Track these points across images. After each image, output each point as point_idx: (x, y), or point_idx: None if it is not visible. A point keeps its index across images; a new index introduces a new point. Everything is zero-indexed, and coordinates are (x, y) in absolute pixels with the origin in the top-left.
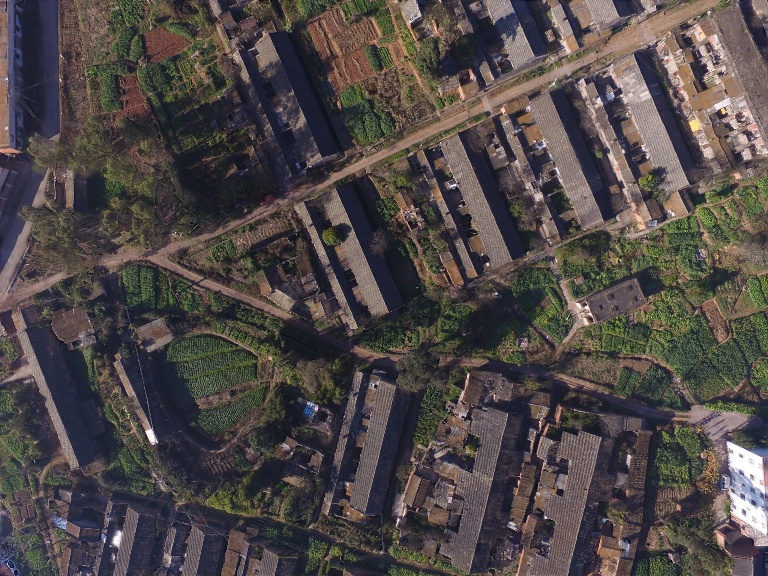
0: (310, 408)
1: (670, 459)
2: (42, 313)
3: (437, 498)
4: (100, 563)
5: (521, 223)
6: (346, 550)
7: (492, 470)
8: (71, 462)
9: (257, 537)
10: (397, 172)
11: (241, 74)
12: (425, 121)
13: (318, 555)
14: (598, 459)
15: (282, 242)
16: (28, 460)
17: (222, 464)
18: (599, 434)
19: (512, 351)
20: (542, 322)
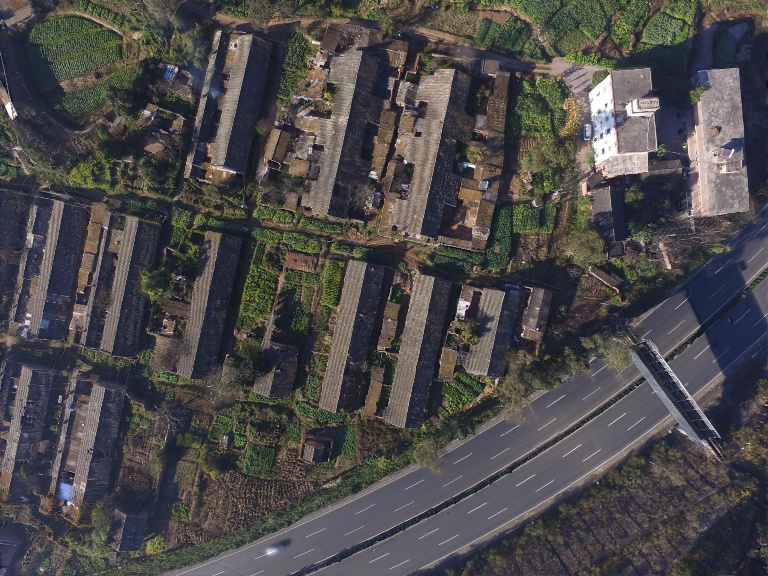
0: (170, 71)
1: (531, 107)
2: None
3: (298, 151)
4: None
5: None
6: (211, 218)
7: (348, 109)
8: None
9: (120, 208)
10: None
11: None
12: None
13: (182, 223)
14: (453, 92)
15: None
16: None
17: (87, 144)
18: (453, 67)
19: (373, 8)
20: None
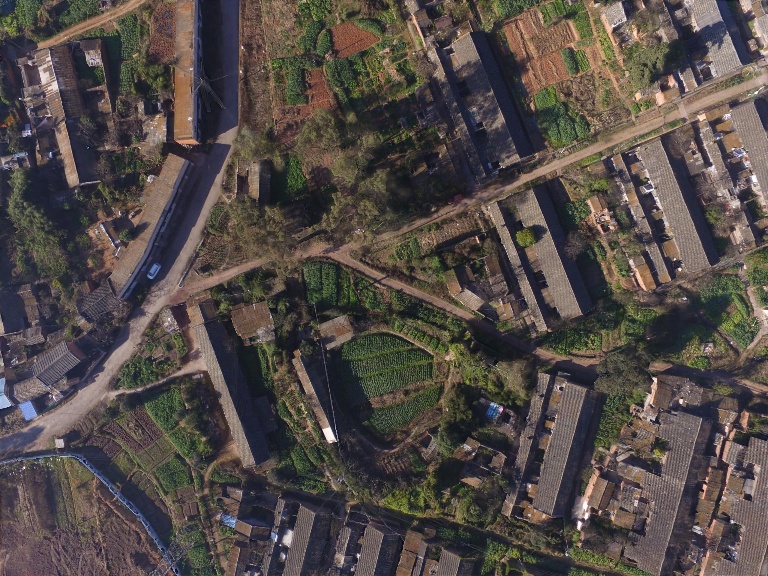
0: (494, 409)
1: None
2: (219, 307)
3: (622, 501)
4: (270, 562)
5: (717, 229)
6: (524, 552)
7: (684, 474)
8: (245, 459)
9: (434, 538)
10: (592, 175)
11: (436, 72)
12: (620, 125)
13: (496, 557)
14: None
15: (470, 242)
16: (199, 457)
17: (396, 464)
18: None
19: (696, 356)
20: (728, 328)
